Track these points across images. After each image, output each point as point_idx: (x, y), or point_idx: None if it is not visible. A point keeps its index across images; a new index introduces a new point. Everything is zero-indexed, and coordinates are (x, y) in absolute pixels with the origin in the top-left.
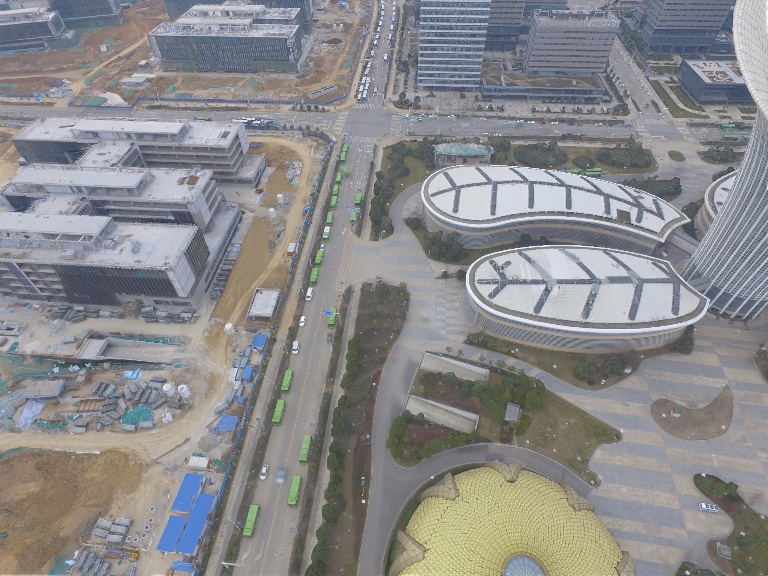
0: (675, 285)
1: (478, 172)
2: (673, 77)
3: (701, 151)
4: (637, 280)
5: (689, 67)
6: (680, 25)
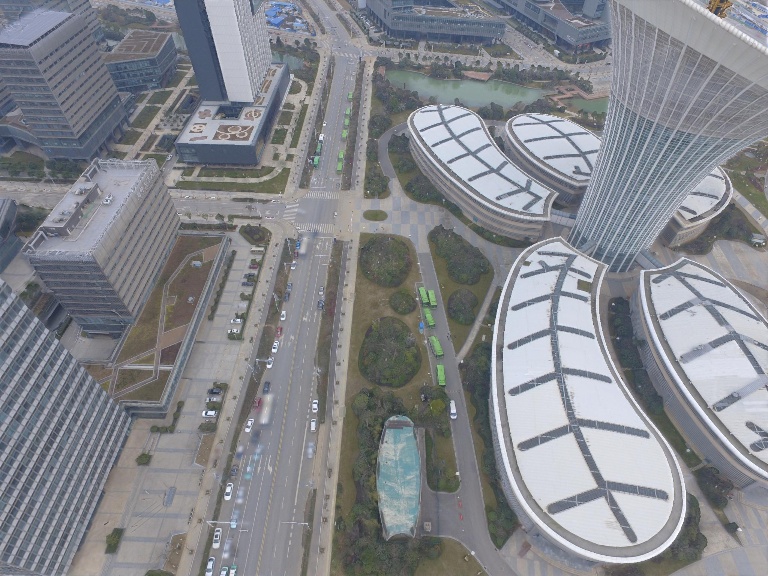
0: (682, 275)
1: (541, 446)
2: (175, 166)
3: (364, 195)
4: (706, 301)
5: (201, 145)
6: (91, 116)
